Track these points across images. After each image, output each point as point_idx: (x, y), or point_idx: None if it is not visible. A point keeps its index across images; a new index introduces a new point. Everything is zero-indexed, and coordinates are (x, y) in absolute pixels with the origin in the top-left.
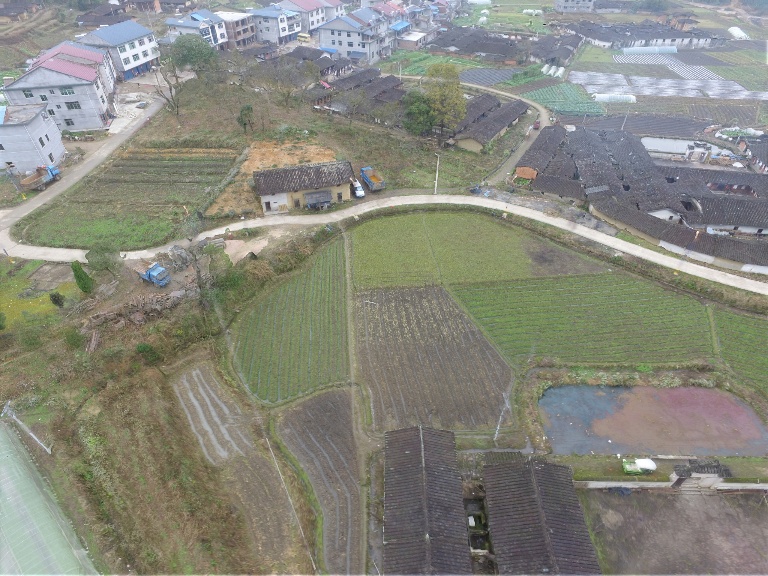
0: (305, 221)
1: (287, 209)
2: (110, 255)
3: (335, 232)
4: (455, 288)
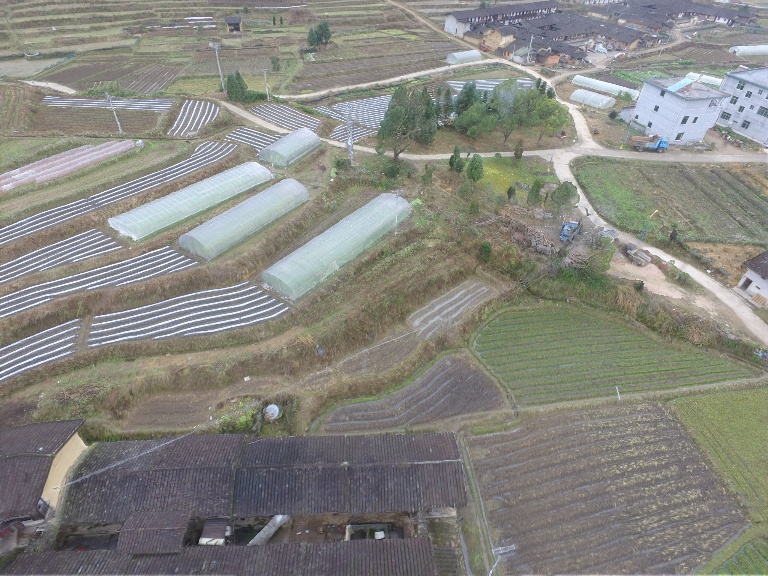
0: (754, 326)
1: (763, 305)
2: (566, 196)
3: (764, 364)
4: (761, 546)
